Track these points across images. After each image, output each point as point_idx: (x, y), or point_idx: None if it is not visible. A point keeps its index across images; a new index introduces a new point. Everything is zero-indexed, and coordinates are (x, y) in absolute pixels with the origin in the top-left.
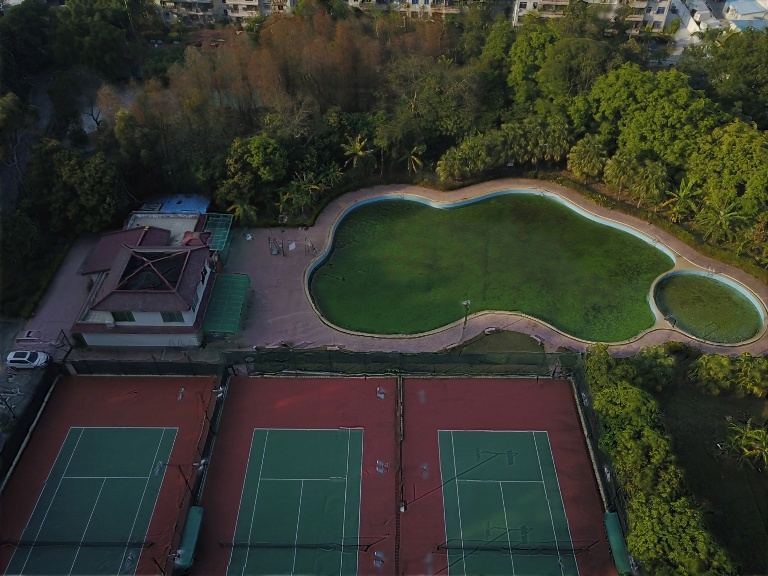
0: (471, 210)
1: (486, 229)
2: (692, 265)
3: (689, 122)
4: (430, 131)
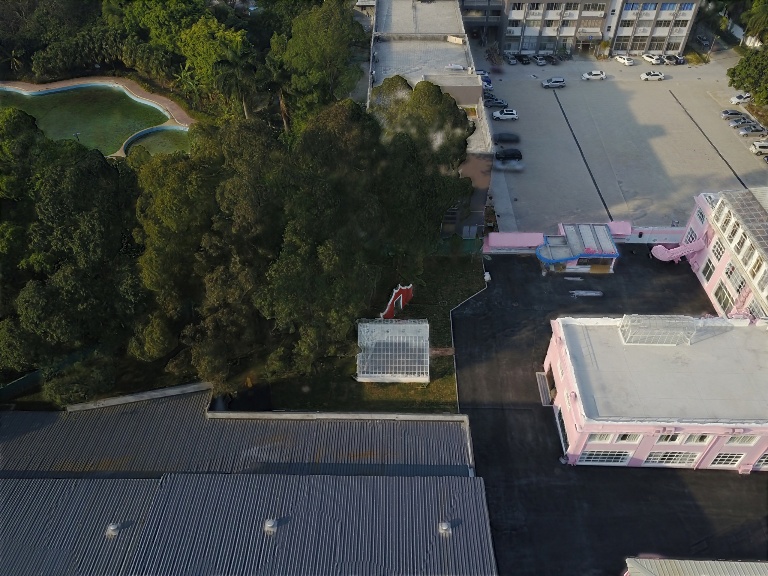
0: (51, 96)
1: (52, 107)
2: (175, 123)
3: (174, 20)
4: (36, 42)
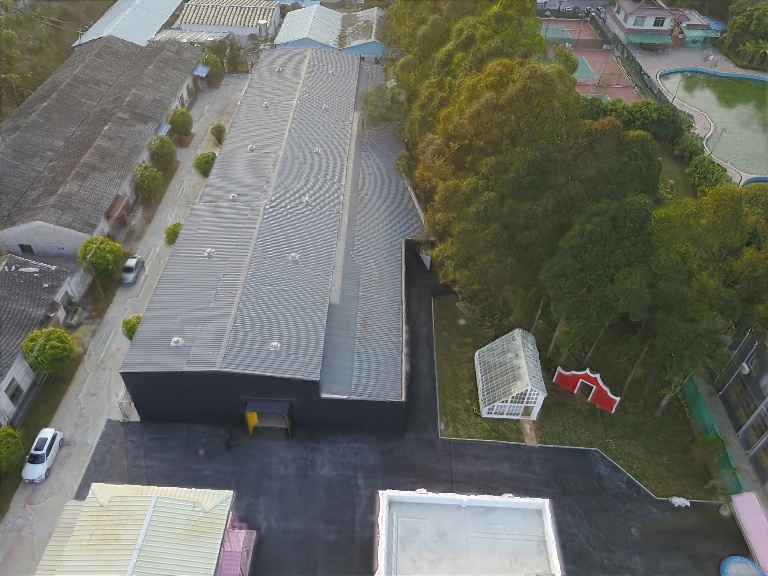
0: None
1: None
2: None
3: None
4: None
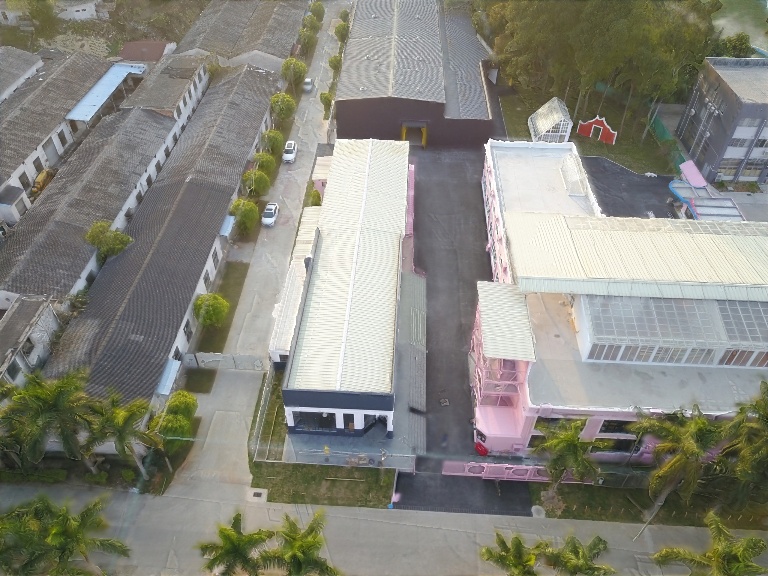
0: None
1: (760, 18)
2: None
3: None
4: None
